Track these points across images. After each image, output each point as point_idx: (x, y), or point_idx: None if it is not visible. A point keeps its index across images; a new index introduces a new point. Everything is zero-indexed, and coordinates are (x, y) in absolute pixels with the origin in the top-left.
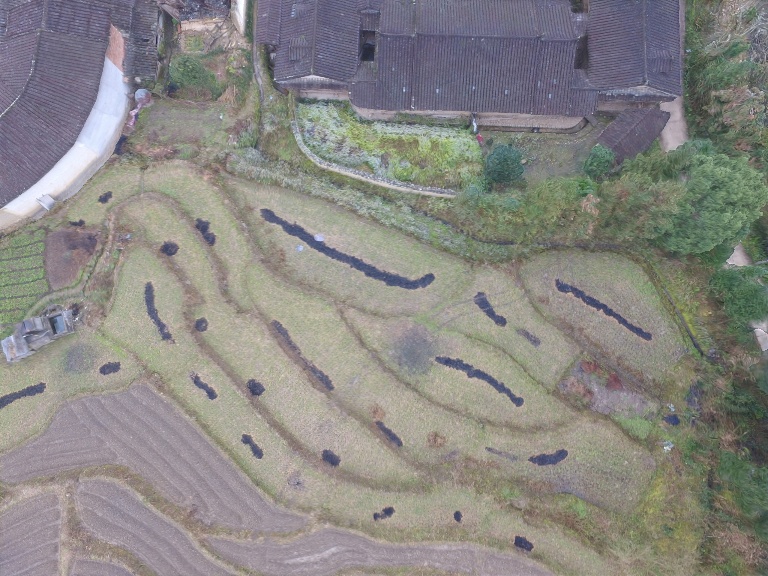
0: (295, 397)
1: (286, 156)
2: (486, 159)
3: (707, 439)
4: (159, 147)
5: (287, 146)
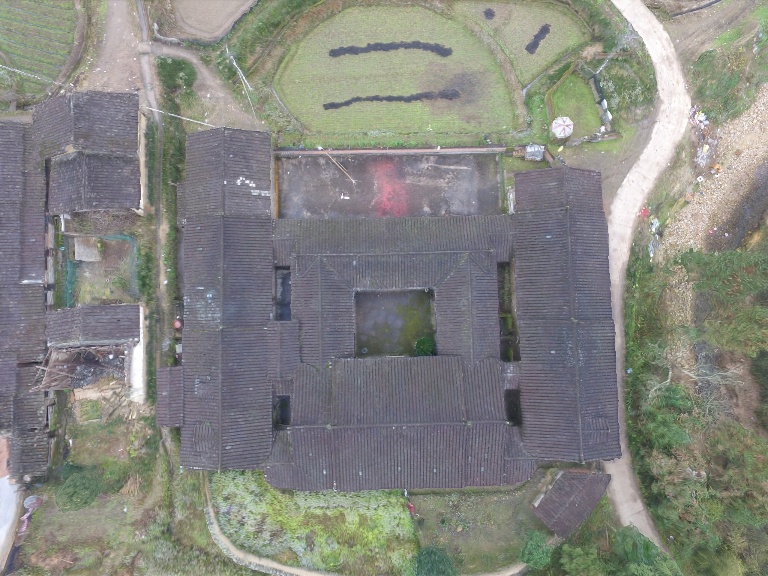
0: None
1: (202, 541)
2: (418, 536)
3: None
4: (57, 556)
5: (202, 530)
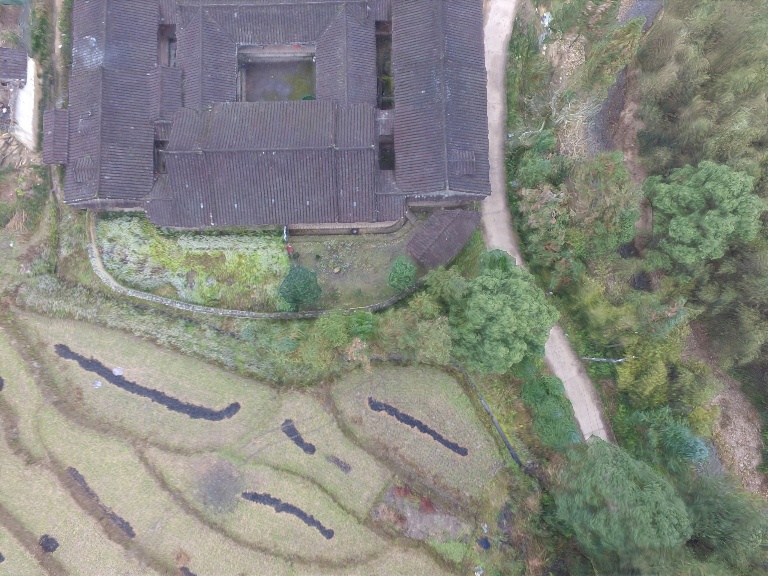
0: (91, 551)
1: (87, 280)
2: None
3: (509, 568)
4: None
5: (87, 269)
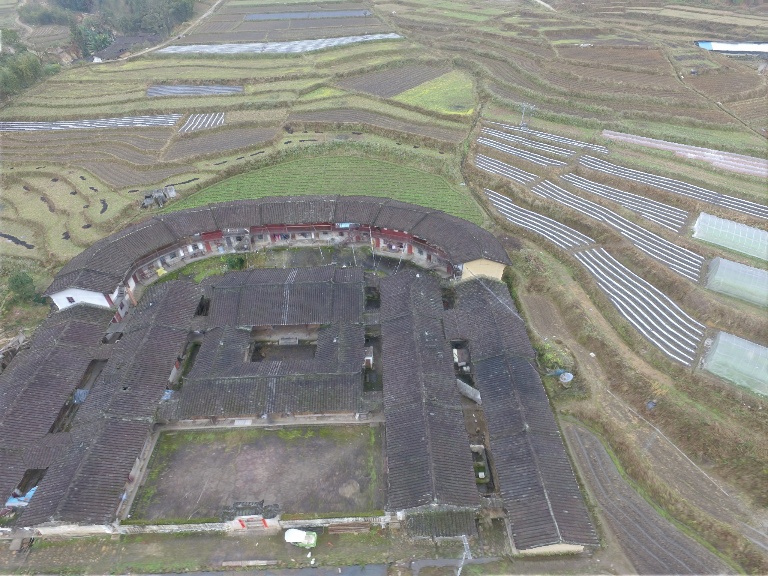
0: None
1: (6, 279)
2: None
3: None
4: None
5: (1, 282)
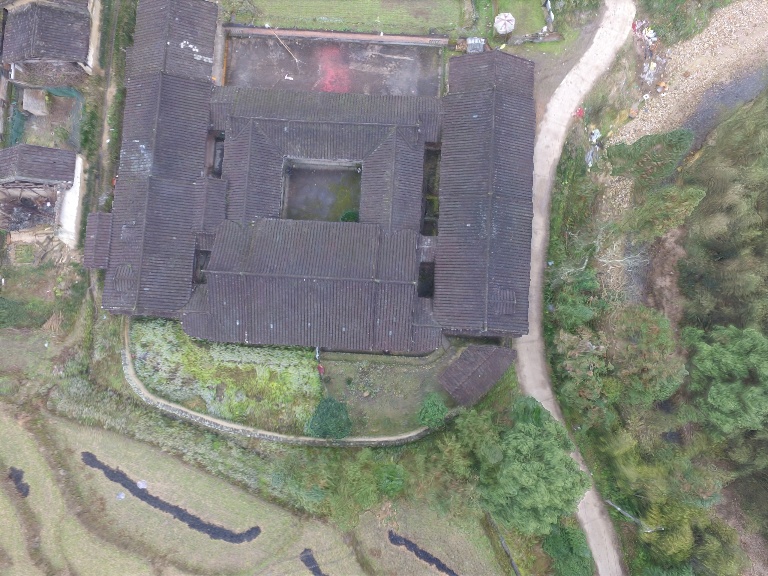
0: None
1: (117, 384)
2: (324, 395)
3: None
4: None
5: (118, 373)
